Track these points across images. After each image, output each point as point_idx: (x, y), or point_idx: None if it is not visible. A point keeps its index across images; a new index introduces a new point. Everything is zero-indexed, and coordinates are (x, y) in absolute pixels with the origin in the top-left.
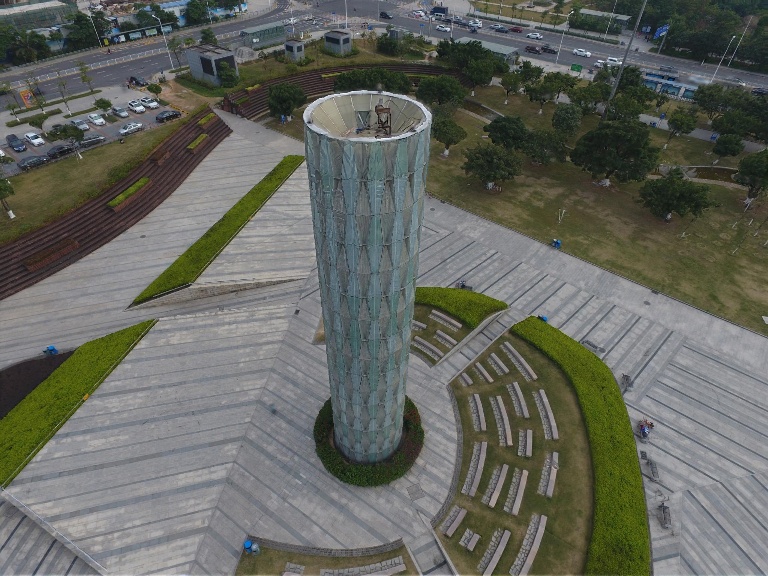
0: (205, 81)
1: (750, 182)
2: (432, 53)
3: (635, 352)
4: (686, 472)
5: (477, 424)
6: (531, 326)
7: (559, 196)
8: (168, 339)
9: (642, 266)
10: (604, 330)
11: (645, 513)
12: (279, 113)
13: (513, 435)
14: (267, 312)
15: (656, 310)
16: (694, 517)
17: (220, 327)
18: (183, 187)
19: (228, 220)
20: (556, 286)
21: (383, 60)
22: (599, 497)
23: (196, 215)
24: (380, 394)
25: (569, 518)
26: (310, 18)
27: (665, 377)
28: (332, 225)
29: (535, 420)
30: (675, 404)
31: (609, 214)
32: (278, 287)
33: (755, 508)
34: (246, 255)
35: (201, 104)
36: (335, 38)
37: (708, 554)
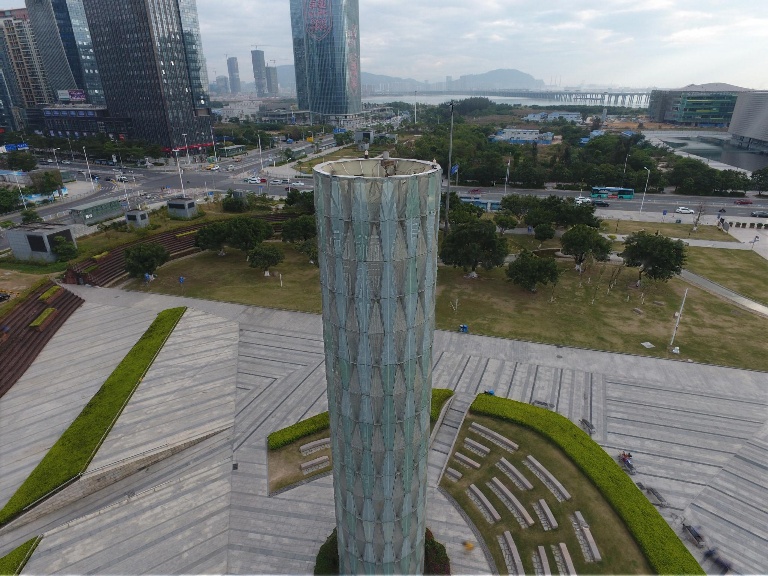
0: (34, 260)
1: (574, 252)
2: (278, 206)
3: (576, 399)
4: (680, 487)
5: (488, 516)
6: (485, 402)
7: (444, 292)
8: (65, 558)
9: (538, 329)
10: (542, 388)
11: (679, 539)
12: (141, 272)
13: (529, 512)
14: (197, 478)
15: (569, 360)
16: (713, 526)
17: (139, 516)
18: (33, 370)
19: (110, 389)
20: (483, 363)
21: (236, 214)
22: (641, 538)
23: (61, 396)
24: (412, 496)
25: (629, 574)
26: (142, 194)
27: (611, 411)
28: (363, 282)
29: (540, 488)
30: (633, 431)
31: (490, 297)
32: (200, 446)
33: (745, 497)
34: (148, 421)
35: (39, 279)
36: (179, 204)
37: (746, 556)
